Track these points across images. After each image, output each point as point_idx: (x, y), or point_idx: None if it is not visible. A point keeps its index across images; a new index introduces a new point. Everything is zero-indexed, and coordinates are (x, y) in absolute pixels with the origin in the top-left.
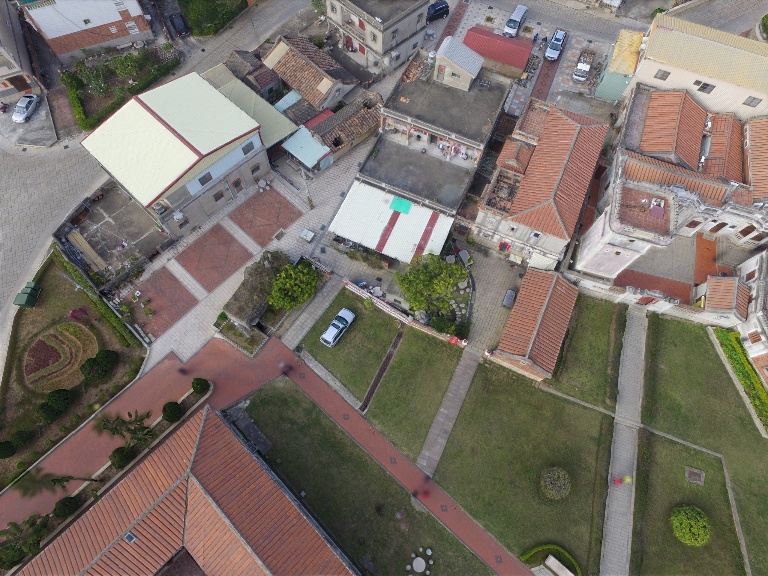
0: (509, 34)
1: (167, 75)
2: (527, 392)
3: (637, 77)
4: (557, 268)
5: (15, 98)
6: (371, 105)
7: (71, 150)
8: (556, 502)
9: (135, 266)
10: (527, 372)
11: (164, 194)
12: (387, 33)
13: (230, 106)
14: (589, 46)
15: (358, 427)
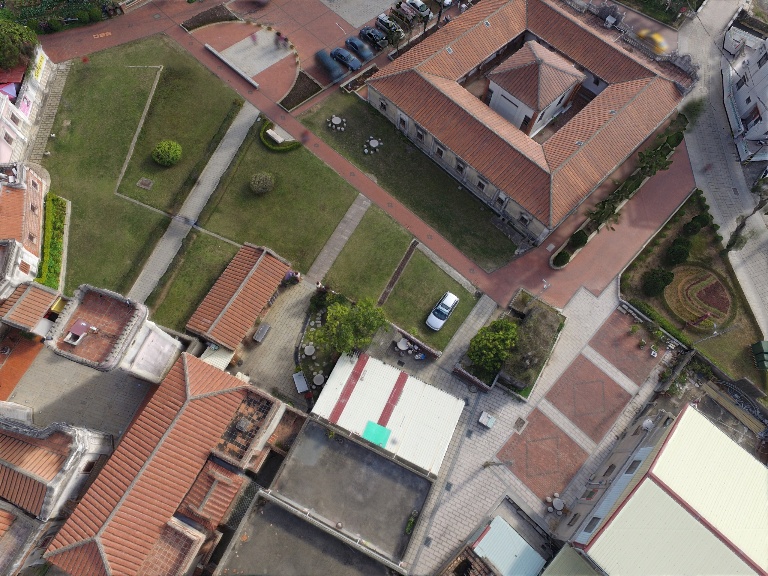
0: None
1: None
2: None
3: None
4: (200, 354)
5: None
6: None
7: None
8: None
9: None
10: None
11: None
12: None
13: None
14: None
15: (419, 229)
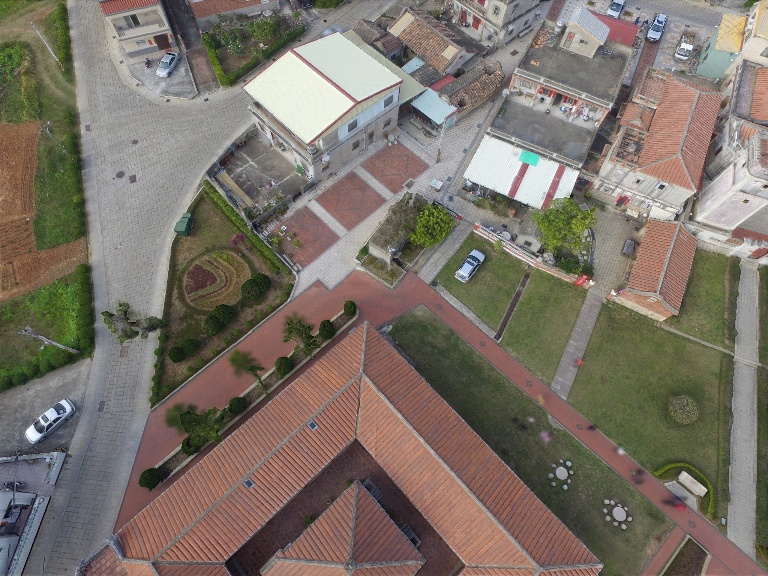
0: (612, 16)
1: (294, 41)
2: (649, 331)
3: (743, 55)
4: None
5: (157, 56)
6: (490, 72)
7: (211, 103)
8: (684, 427)
9: (282, 203)
10: (651, 311)
11: (322, 134)
12: (510, 6)
13: (374, 62)
14: (687, 30)
15: (494, 353)
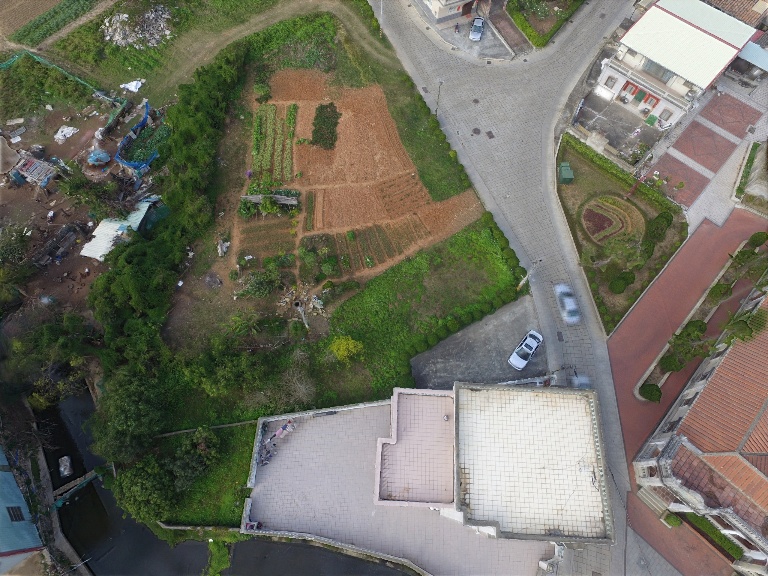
0: None
1: (583, 4)
2: None
3: None
4: None
5: (460, 21)
6: None
7: (531, 63)
8: None
9: None
10: None
11: None
12: None
13: (724, 15)
14: None
15: None
